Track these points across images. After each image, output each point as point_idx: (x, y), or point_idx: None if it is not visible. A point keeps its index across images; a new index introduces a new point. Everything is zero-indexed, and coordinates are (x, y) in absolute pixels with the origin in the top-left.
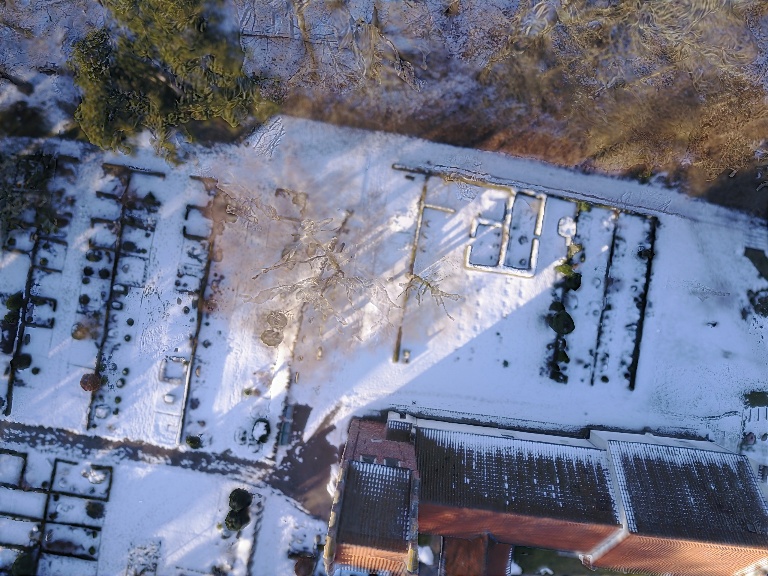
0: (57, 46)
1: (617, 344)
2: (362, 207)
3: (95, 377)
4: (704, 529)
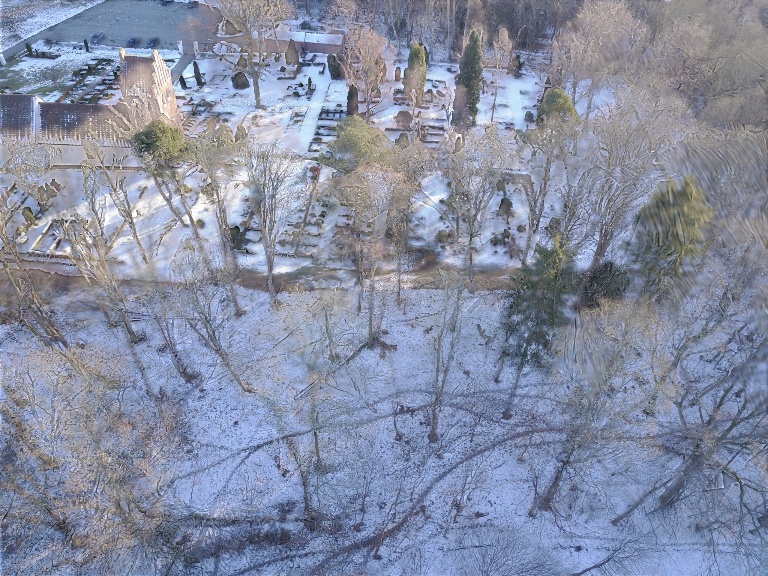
0: (337, 302)
1: (15, 200)
2: (149, 246)
3: (311, 171)
4: (0, 101)
